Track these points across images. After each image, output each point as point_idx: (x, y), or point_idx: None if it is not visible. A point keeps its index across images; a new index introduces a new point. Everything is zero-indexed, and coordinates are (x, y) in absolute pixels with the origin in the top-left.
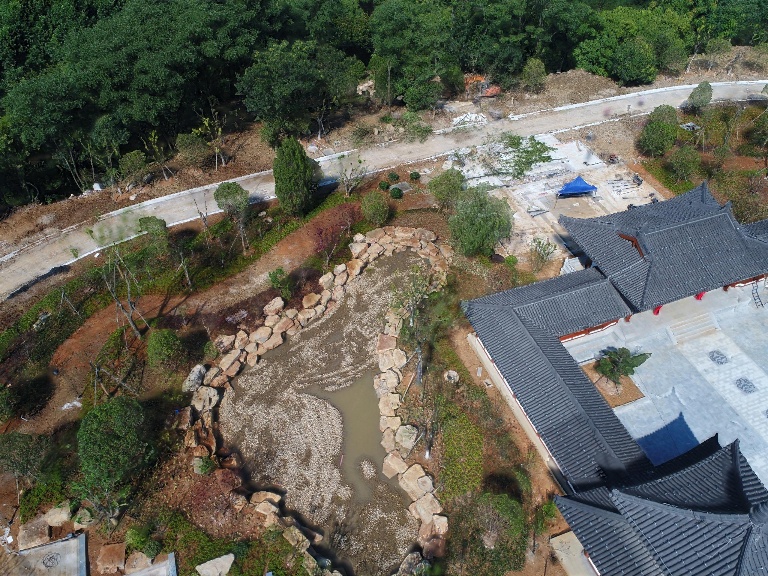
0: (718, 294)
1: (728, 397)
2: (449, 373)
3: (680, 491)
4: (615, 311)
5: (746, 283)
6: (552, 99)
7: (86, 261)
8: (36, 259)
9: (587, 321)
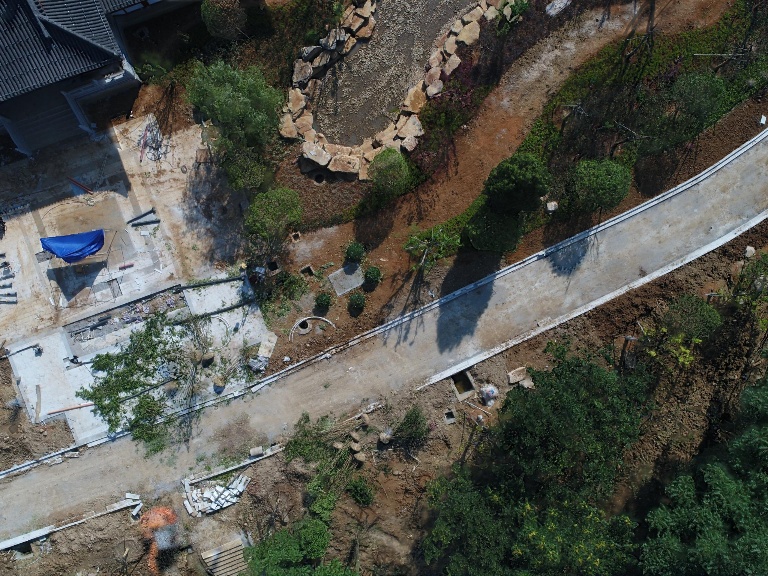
0: None
1: None
2: None
3: None
4: None
5: None
6: (48, 567)
7: None
8: None
9: None
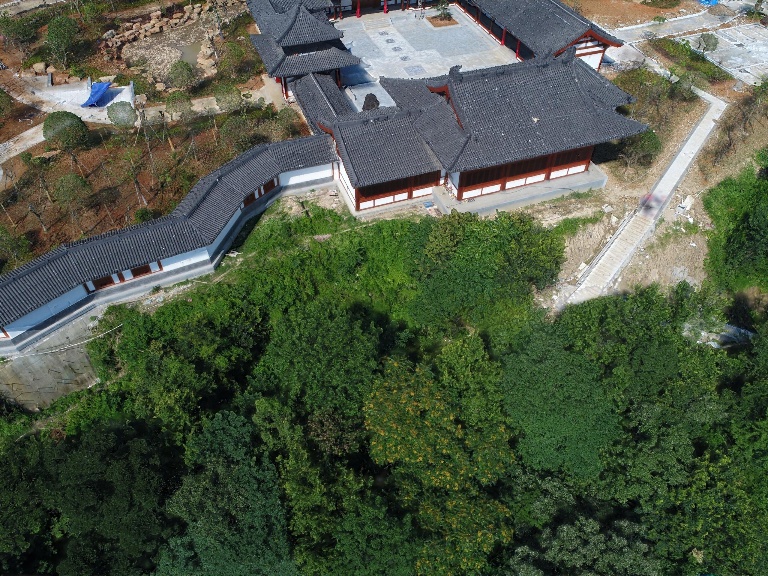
0: (398, 12)
1: (378, 44)
2: (240, 37)
3: None
4: (324, 4)
5: (416, 9)
6: None
7: (59, 3)
8: (32, 3)
9: (308, 6)
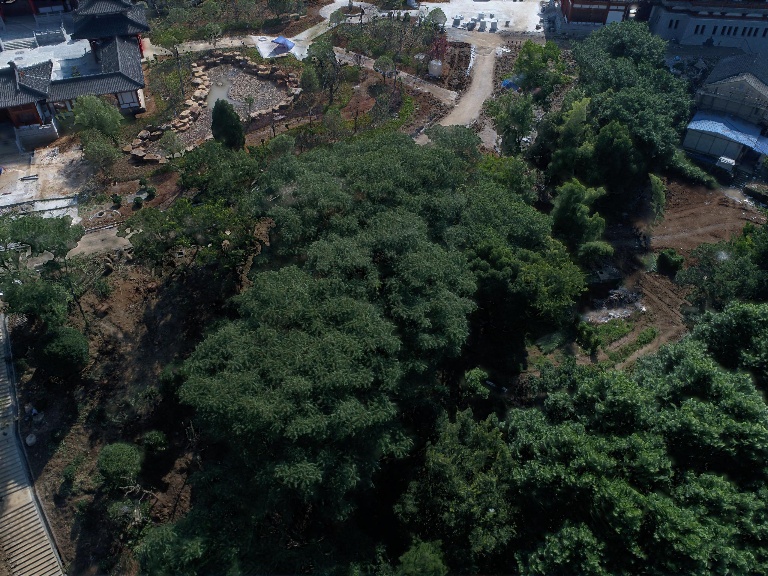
0: None
1: None
2: None
3: (109, 7)
4: None
5: None
6: None
7: None
8: None
9: None
